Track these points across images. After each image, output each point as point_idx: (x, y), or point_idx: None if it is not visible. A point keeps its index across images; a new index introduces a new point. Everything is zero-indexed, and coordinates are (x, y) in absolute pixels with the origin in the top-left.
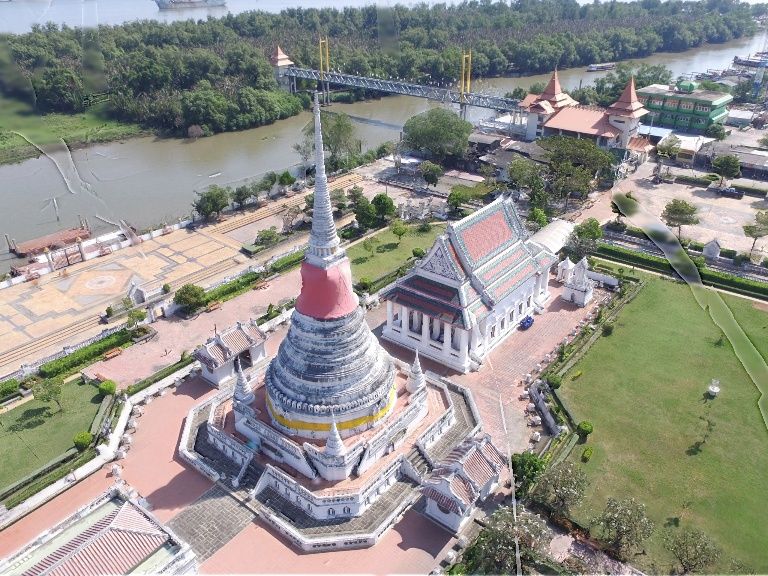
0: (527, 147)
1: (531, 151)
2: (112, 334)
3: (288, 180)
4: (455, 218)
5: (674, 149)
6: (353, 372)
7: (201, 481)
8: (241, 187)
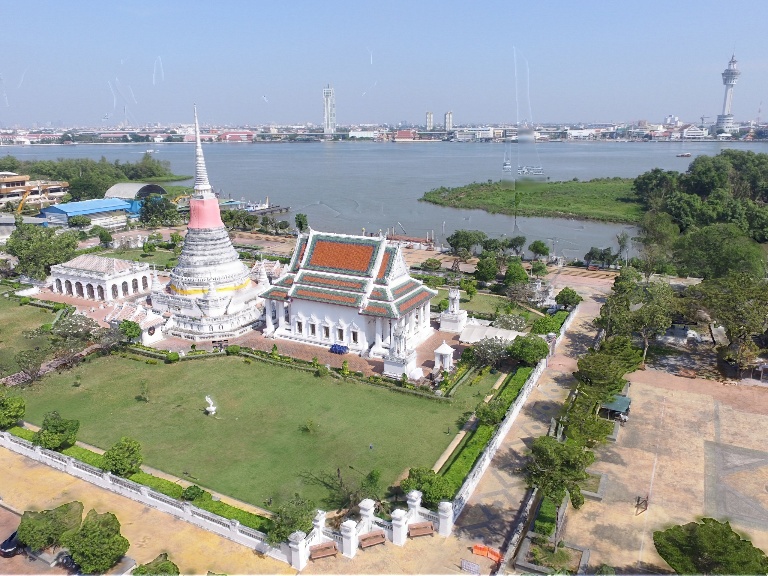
0: None
1: None
2: None
3: (536, 249)
4: (552, 314)
5: None
6: (181, 259)
7: None
8: (494, 239)
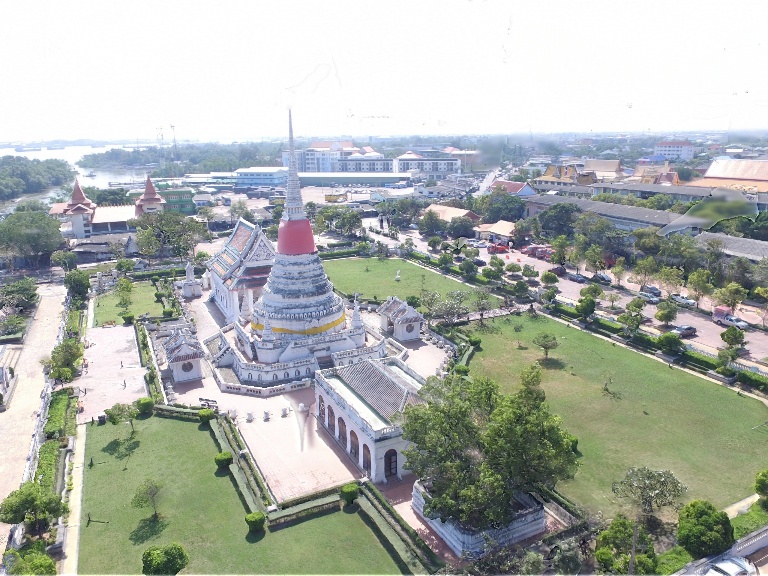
0: (94, 240)
1: (102, 241)
2: (53, 397)
3: None
4: (132, 281)
5: (211, 215)
6: None
7: (302, 391)
8: None
